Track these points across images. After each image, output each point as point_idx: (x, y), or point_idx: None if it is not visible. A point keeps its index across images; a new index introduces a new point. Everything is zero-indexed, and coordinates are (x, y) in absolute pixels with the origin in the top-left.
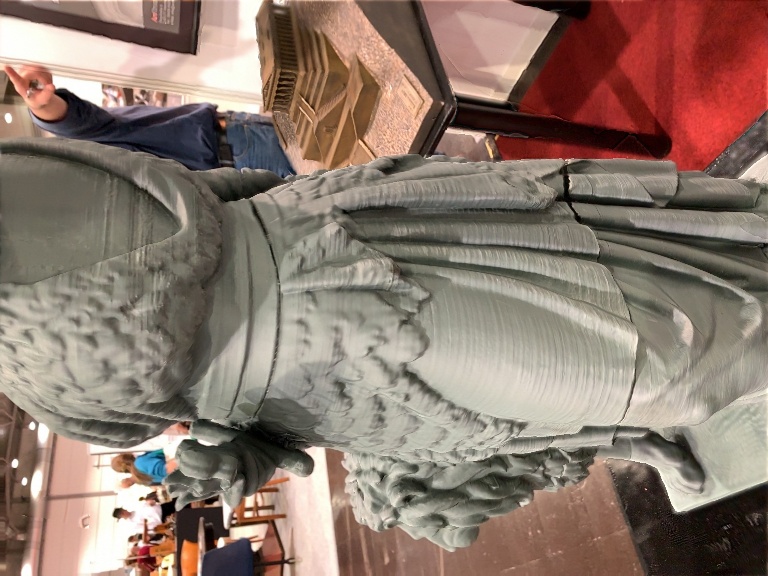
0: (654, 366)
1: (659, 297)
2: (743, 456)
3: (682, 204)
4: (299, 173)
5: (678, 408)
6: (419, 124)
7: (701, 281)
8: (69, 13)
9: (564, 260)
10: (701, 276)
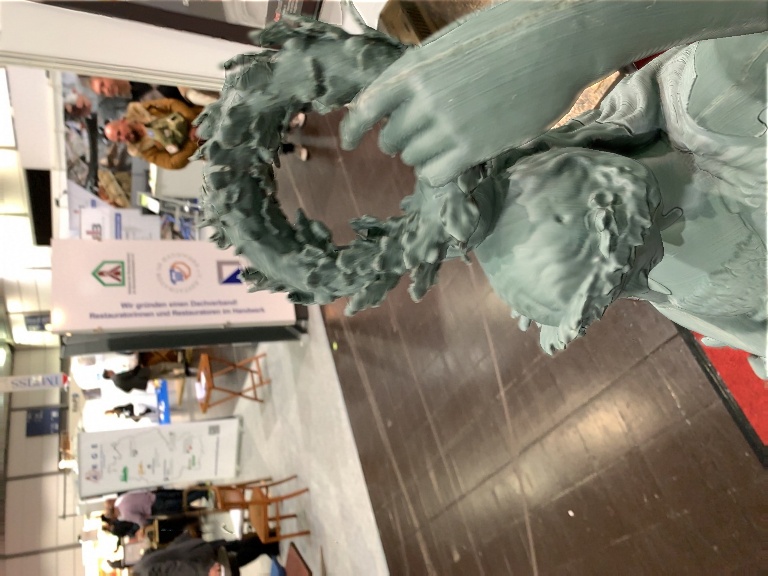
0: None
1: None
2: None
3: None
4: None
5: None
6: (599, 97)
7: None
8: (196, 16)
9: None
10: None
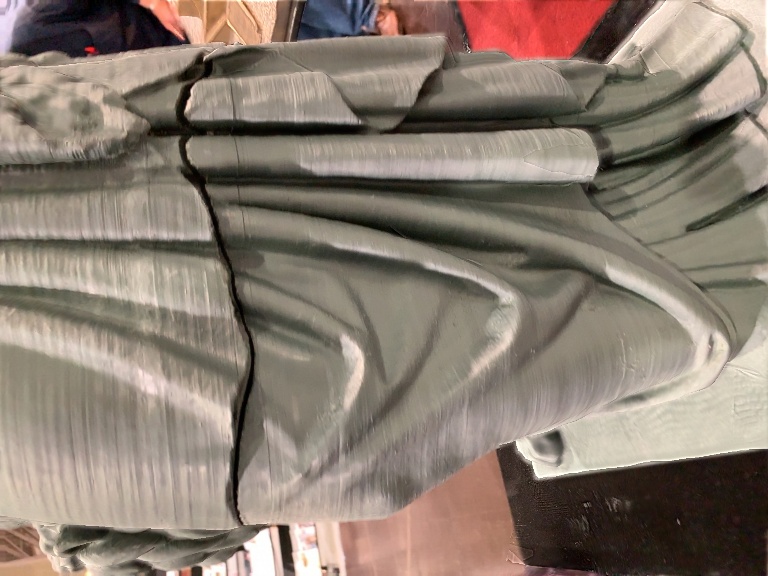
0: (276, 450)
1: (332, 308)
2: (601, 434)
3: (443, 117)
4: (188, 33)
5: (333, 507)
6: None
7: (423, 270)
8: None
9: (132, 259)
10: (421, 262)
